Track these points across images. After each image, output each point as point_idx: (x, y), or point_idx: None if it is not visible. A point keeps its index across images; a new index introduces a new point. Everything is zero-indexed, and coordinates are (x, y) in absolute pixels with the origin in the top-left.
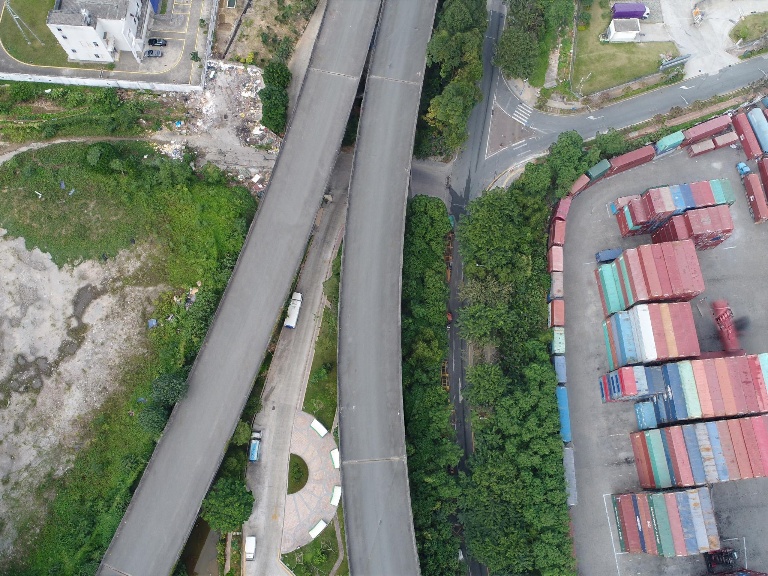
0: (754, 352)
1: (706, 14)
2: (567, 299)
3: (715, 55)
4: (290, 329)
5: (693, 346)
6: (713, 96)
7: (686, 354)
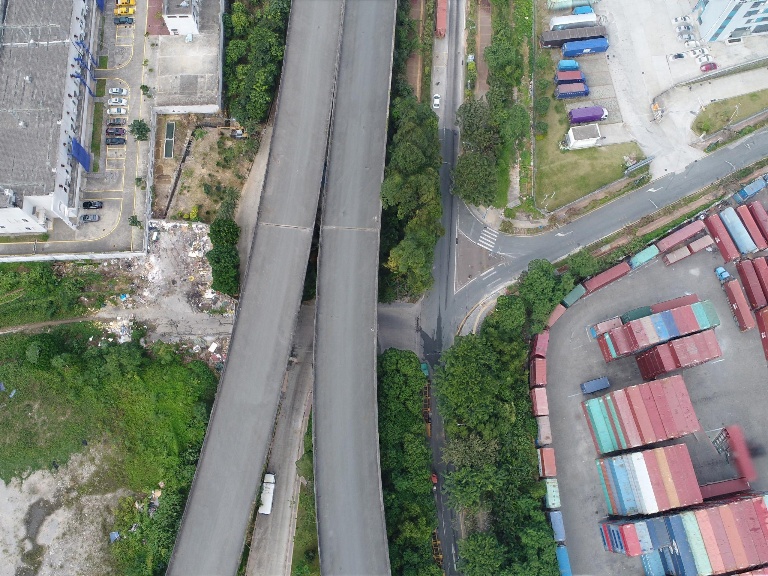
0: (756, 474)
1: (665, 108)
2: (556, 438)
3: (679, 151)
4: (265, 515)
5: (694, 493)
6: (683, 199)
7: (688, 503)
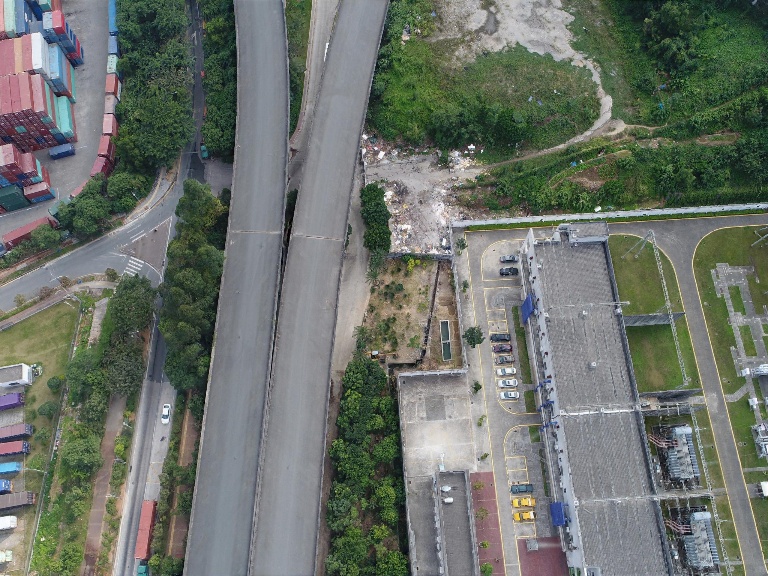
0: None
1: None
2: None
3: None
4: None
5: (1, 47)
6: None
7: (8, 41)
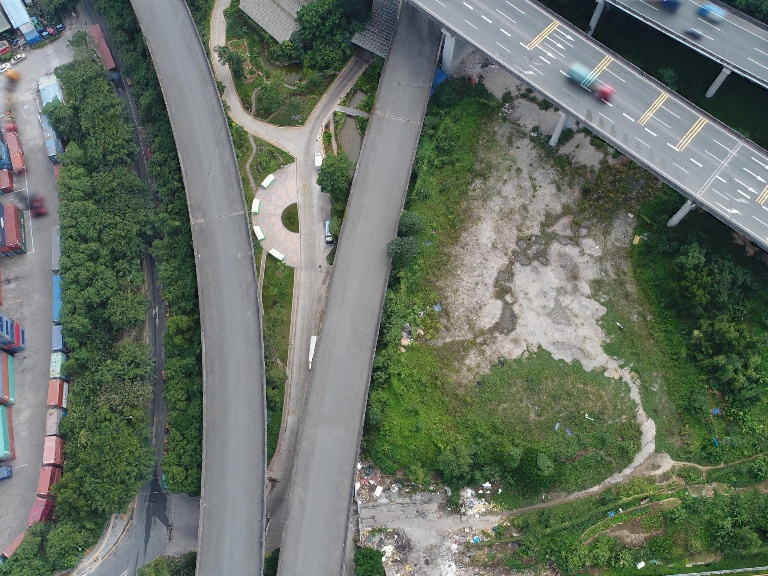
0: None
1: None
2: None
3: None
4: None
5: None
6: None
7: None
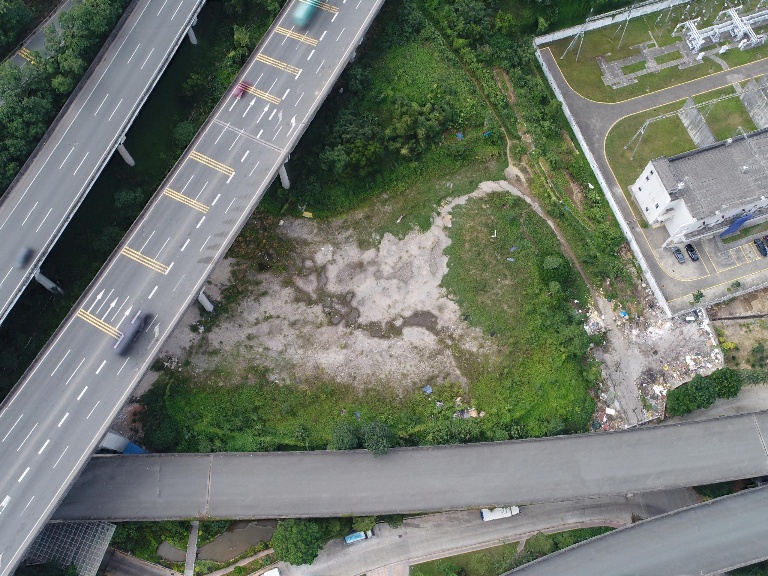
0: None
1: None
2: None
3: None
4: (481, 516)
5: None
6: None
7: None
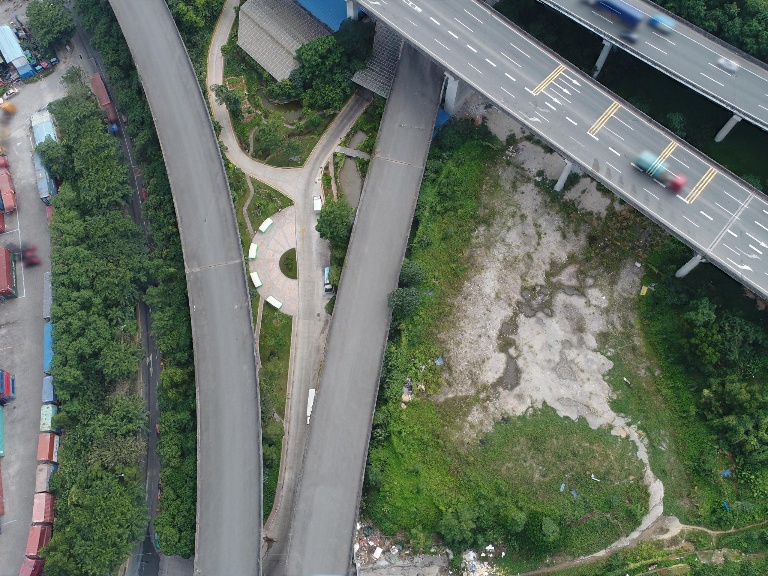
0: None
1: None
2: None
3: None
4: None
5: None
6: None
7: None
